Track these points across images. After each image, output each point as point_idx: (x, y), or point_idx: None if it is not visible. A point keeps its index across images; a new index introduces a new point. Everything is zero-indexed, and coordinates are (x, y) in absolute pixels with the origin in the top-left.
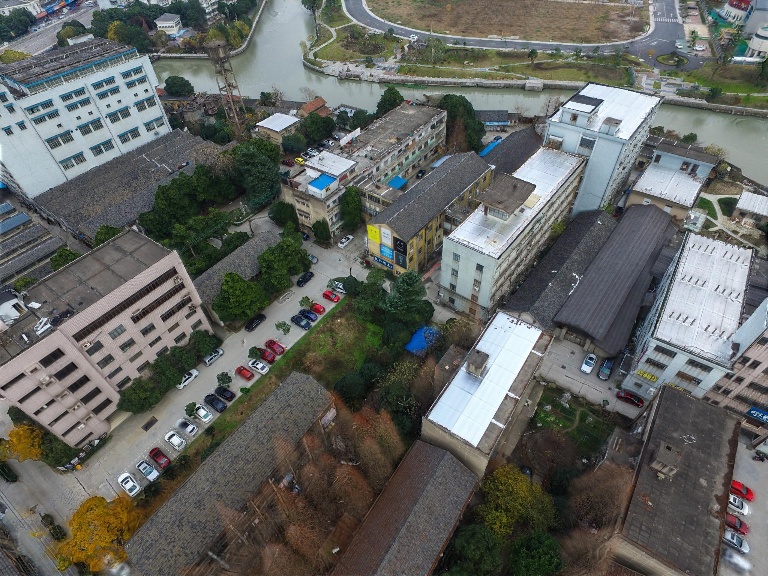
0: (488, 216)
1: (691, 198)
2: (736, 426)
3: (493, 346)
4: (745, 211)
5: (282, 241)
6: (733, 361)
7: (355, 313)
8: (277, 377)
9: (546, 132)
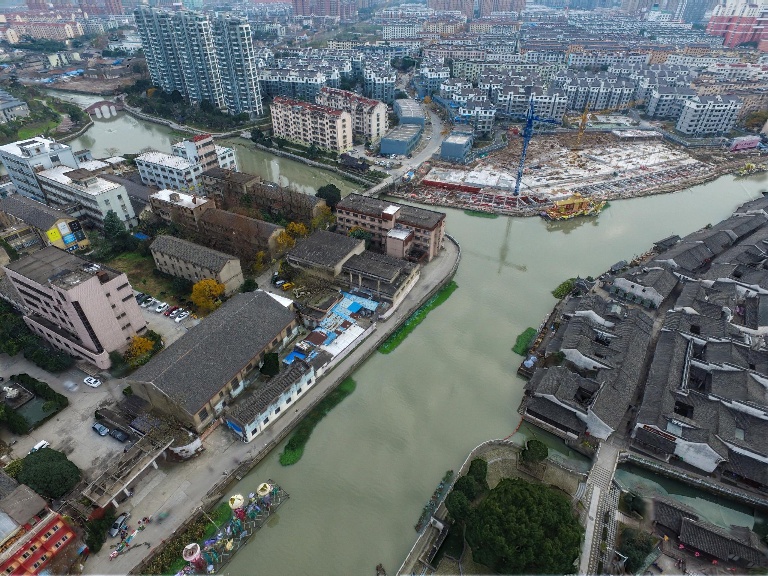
0: (88, 187)
1: (104, 164)
2: (219, 168)
3: (167, 197)
4: (117, 163)
5: None
6: (199, 160)
7: (106, 260)
8: (136, 284)
9: (29, 166)
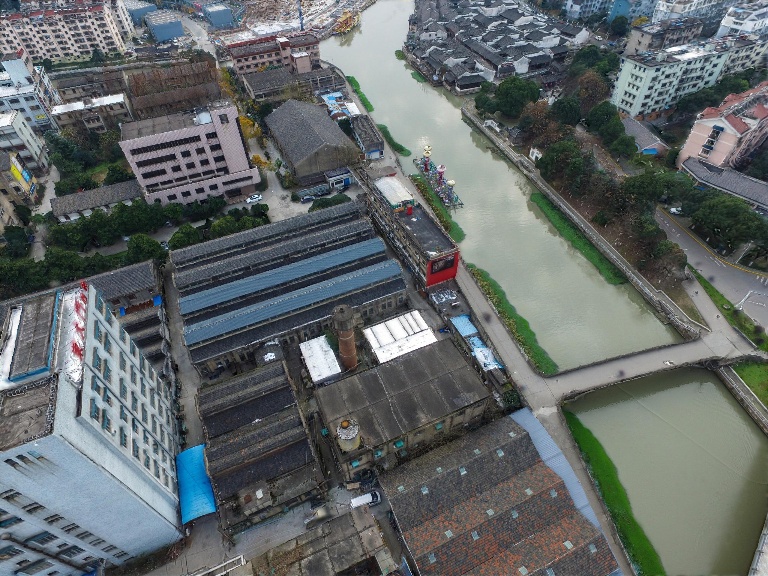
0: None
1: None
2: None
3: None
4: None
5: (60, 182)
6: None
7: None
8: None
9: None
